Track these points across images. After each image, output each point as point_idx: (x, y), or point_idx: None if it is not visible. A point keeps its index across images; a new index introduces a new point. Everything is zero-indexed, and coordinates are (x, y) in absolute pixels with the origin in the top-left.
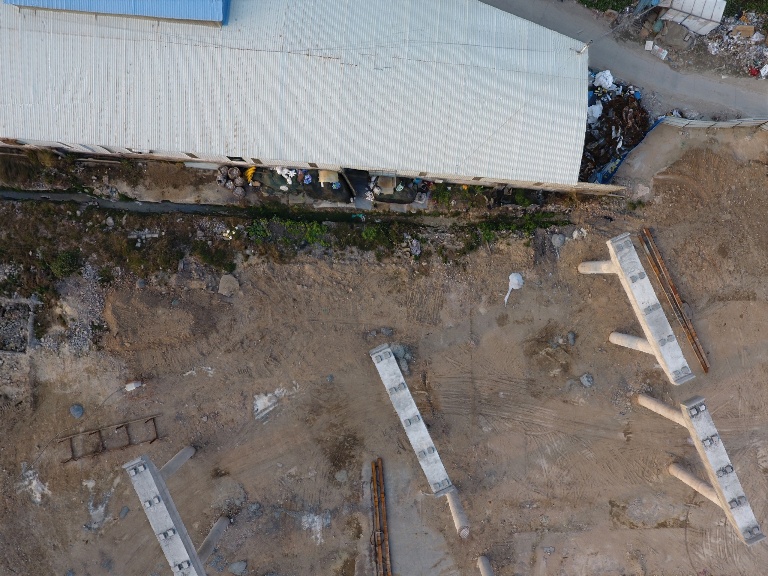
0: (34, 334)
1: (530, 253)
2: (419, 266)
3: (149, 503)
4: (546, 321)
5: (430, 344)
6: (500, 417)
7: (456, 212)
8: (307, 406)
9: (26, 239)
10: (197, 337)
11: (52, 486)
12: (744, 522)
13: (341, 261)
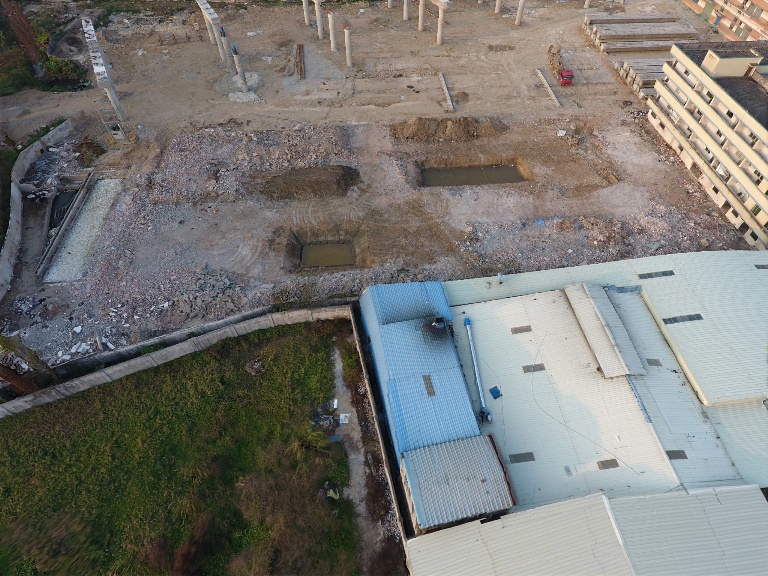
0: (158, 22)
1: (367, 5)
2: (322, 8)
3: (203, 3)
4: (376, 17)
5: (326, 22)
6: (357, 35)
7: (338, 0)
8: (270, 34)
9: (165, 5)
10: (227, 20)
11: (148, 51)
12: (444, 1)
13: (290, 7)
